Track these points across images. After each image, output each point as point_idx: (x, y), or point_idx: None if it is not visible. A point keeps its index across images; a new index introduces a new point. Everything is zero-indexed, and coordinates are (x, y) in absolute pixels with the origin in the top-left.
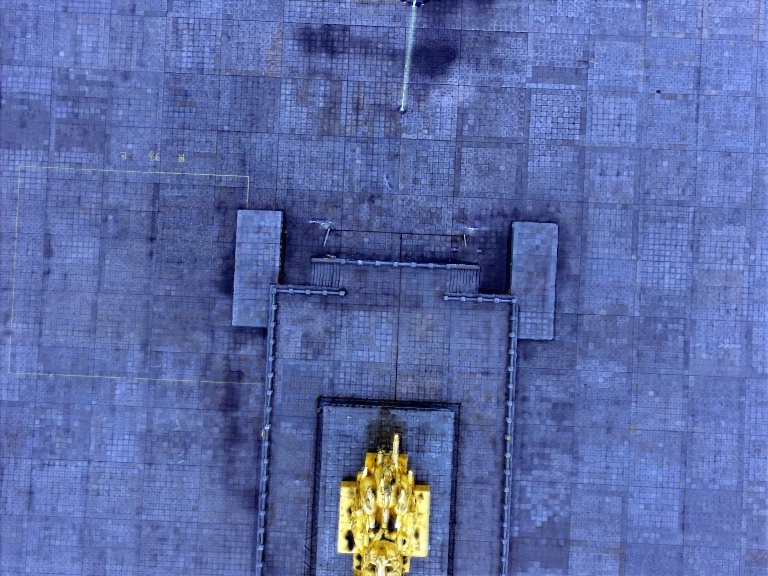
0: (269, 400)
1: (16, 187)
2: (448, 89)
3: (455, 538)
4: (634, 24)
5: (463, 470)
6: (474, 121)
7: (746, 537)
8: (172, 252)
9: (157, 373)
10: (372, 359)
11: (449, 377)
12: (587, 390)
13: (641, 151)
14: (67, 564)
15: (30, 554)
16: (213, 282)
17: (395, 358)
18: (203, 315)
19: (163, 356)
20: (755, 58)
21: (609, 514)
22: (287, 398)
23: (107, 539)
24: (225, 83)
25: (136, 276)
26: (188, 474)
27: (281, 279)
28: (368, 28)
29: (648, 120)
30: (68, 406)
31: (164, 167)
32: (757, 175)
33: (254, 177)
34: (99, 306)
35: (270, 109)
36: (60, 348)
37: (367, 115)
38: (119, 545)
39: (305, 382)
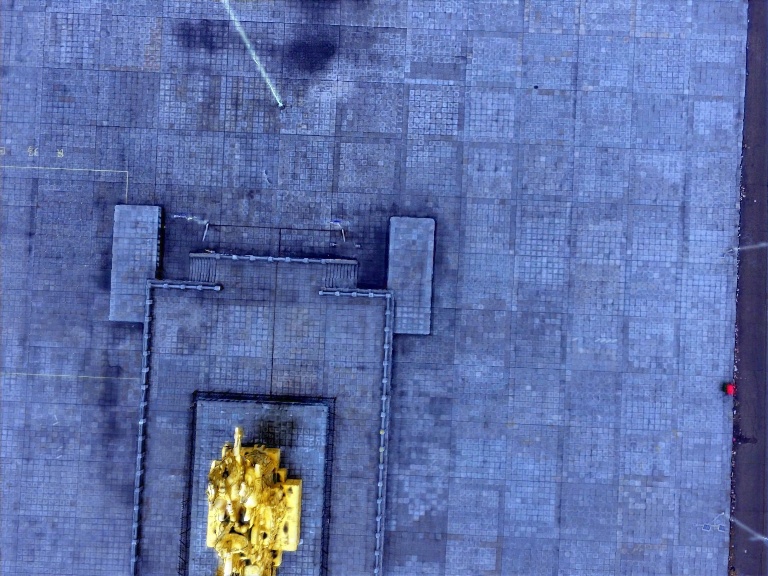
0: (143, 395)
1: None
2: (327, 84)
3: (330, 532)
4: (512, 20)
5: (338, 464)
6: (353, 116)
7: (622, 530)
8: (51, 247)
9: (35, 368)
10: (248, 354)
11: (325, 372)
12: (465, 384)
13: (519, 146)
14: None
15: None
16: (92, 277)
17: (271, 353)
18: (82, 310)
19: (41, 351)
20: (632, 54)
21: (486, 508)
22: (163, 393)
23: None
24: (104, 78)
25: (15, 271)
26: (66, 469)
27: (159, 274)
28: (247, 23)
29: (526, 116)
30: None
31: (43, 162)
32: (634, 170)
33: (133, 172)
34: None
35: (149, 104)
36: None
37: (246, 110)
38: None
39: (181, 377)
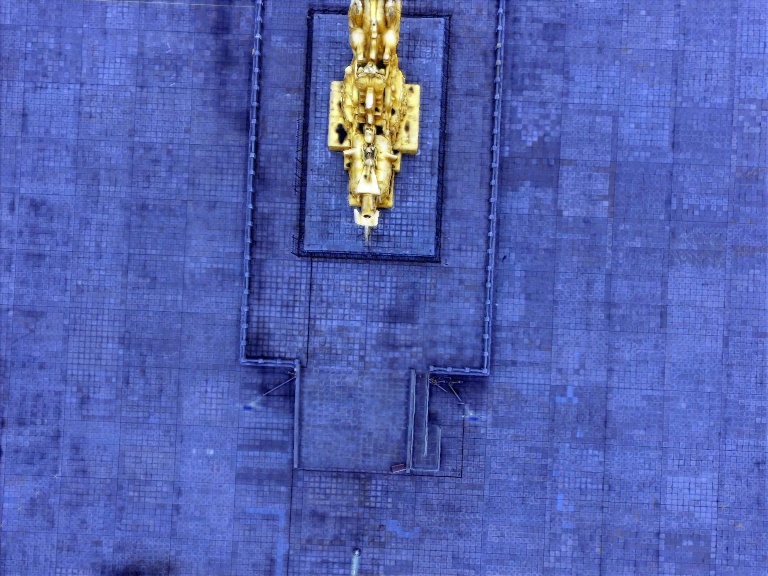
0: (259, 10)
1: None
2: None
3: (445, 149)
4: None
5: (453, 82)
6: None
7: (736, 154)
8: None
9: None
10: None
11: None
12: (578, 10)
13: None
14: (61, 185)
15: (24, 175)
16: None
17: None
18: None
19: None
20: None
21: (599, 133)
22: (277, 12)
23: (100, 161)
24: None
25: None
26: (180, 96)
27: None
28: None
29: None
30: (59, 29)
31: None
32: None
33: None
34: None
35: None
36: None
37: None
38: (112, 166)
39: None
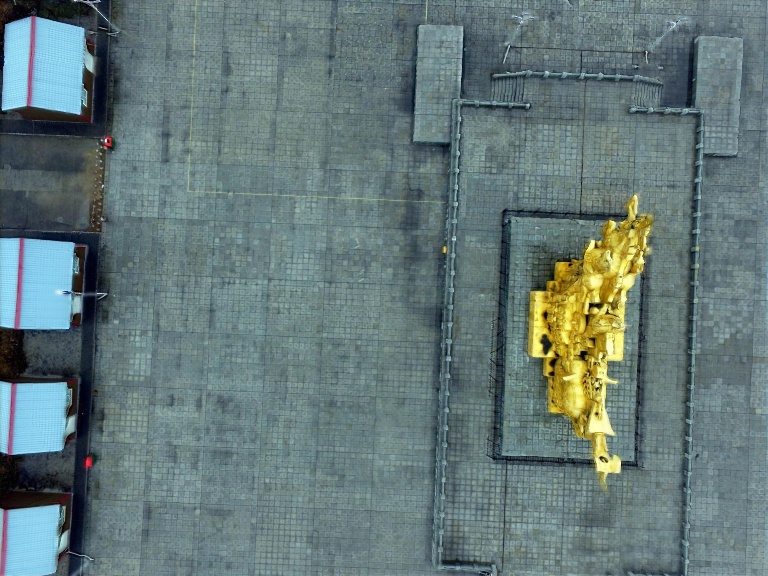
0: (455, 212)
1: (194, 4)
2: None
3: (641, 351)
4: None
5: (649, 283)
6: None
7: None
8: (351, 70)
9: (336, 191)
10: (557, 173)
11: (634, 190)
12: None
13: None
14: (248, 381)
15: (211, 372)
16: (392, 100)
17: (580, 172)
18: (382, 133)
19: (342, 174)
20: None
21: None
22: (471, 212)
23: (288, 357)
24: None
25: (315, 94)
26: (368, 292)
27: (462, 96)
28: None
29: None
30: (247, 225)
31: None
32: None
33: None
34: (278, 124)
35: None
36: (239, 166)
37: None
38: (300, 363)
39: (489, 196)
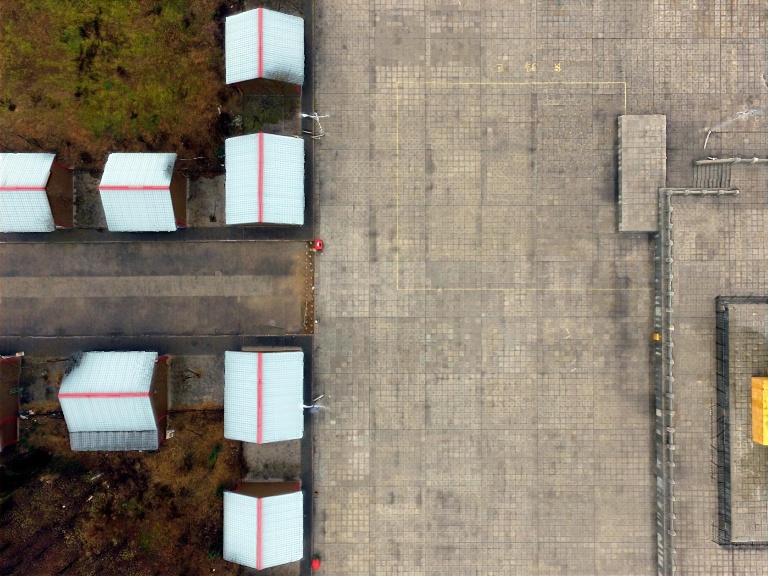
0: None
1: (395, 104)
2: None
3: None
4: None
5: None
6: None
7: None
8: (553, 162)
9: (545, 283)
10: (767, 257)
11: None
12: None
13: None
14: (467, 476)
15: (429, 468)
16: (595, 190)
17: None
18: (587, 223)
19: (550, 266)
20: None
21: None
22: (684, 299)
23: (505, 449)
24: None
25: (518, 187)
26: (581, 382)
27: None
28: None
29: None
30: (458, 320)
31: (541, 77)
32: None
33: (631, 83)
34: (483, 219)
35: (644, 14)
36: (447, 262)
37: (741, 16)
38: (517, 455)
39: (702, 283)
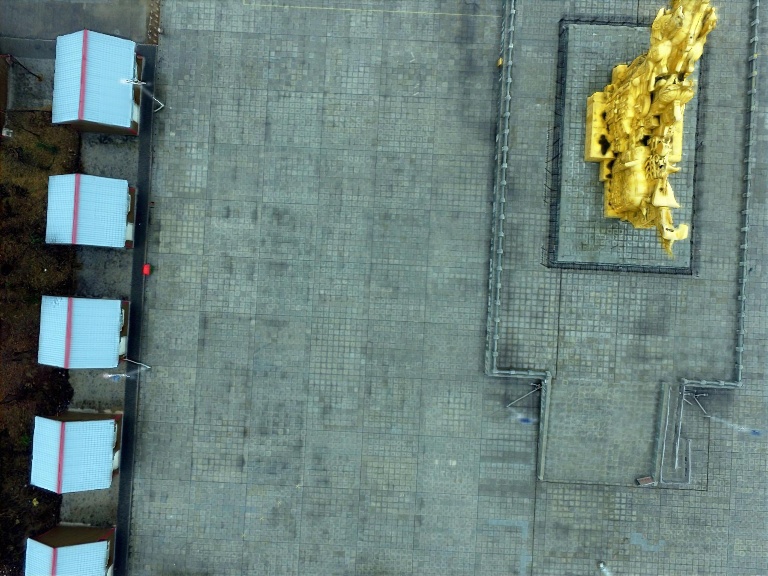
0: (512, 20)
1: None
2: None
3: (697, 160)
4: None
5: (705, 93)
6: None
7: None
8: None
9: (392, 5)
10: None
11: None
12: None
13: None
14: (303, 194)
15: (267, 184)
16: None
17: None
18: None
19: None
20: None
21: None
22: (528, 22)
23: (343, 170)
24: None
25: None
26: (423, 106)
27: None
28: None
29: None
30: (303, 38)
31: None
32: None
33: None
34: None
35: None
36: None
37: None
38: (355, 176)
39: (546, 6)
